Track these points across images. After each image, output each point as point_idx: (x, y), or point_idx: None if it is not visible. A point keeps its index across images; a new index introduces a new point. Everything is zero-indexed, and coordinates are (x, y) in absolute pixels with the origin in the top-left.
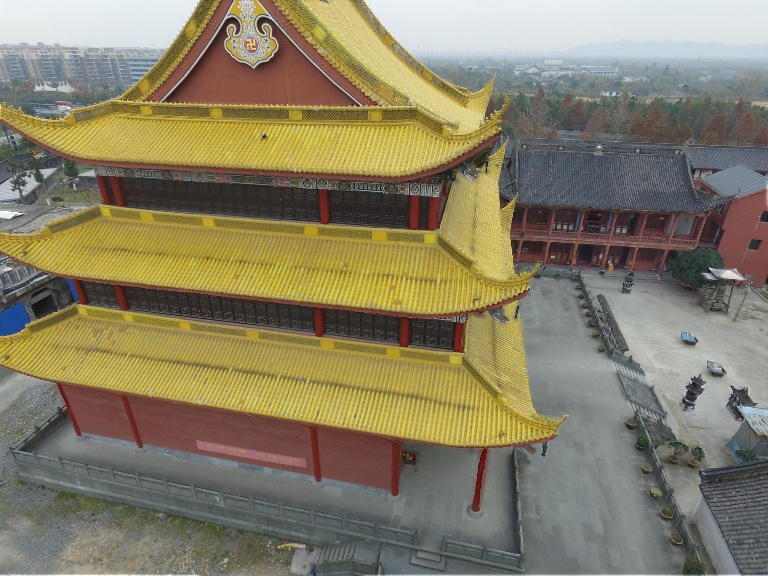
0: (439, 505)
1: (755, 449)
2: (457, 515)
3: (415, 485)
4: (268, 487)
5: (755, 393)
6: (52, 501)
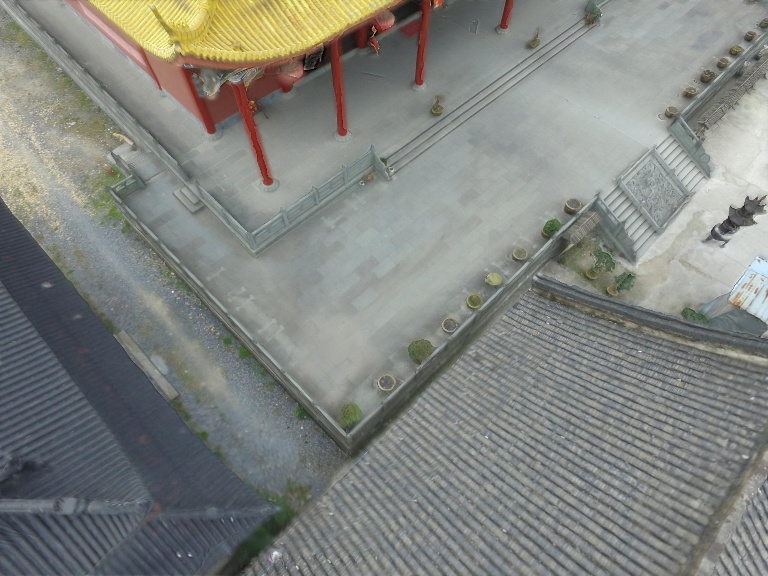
0: (243, 163)
1: (716, 319)
2: (249, 179)
3: (241, 136)
4: (122, 76)
5: None
6: (4, 25)
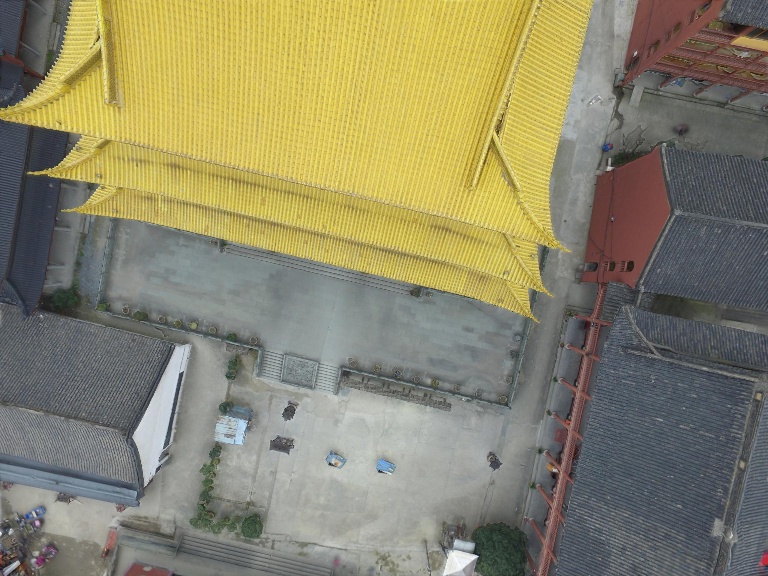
0: None
1: None
2: None
3: None
4: None
5: (310, 476)
6: None
